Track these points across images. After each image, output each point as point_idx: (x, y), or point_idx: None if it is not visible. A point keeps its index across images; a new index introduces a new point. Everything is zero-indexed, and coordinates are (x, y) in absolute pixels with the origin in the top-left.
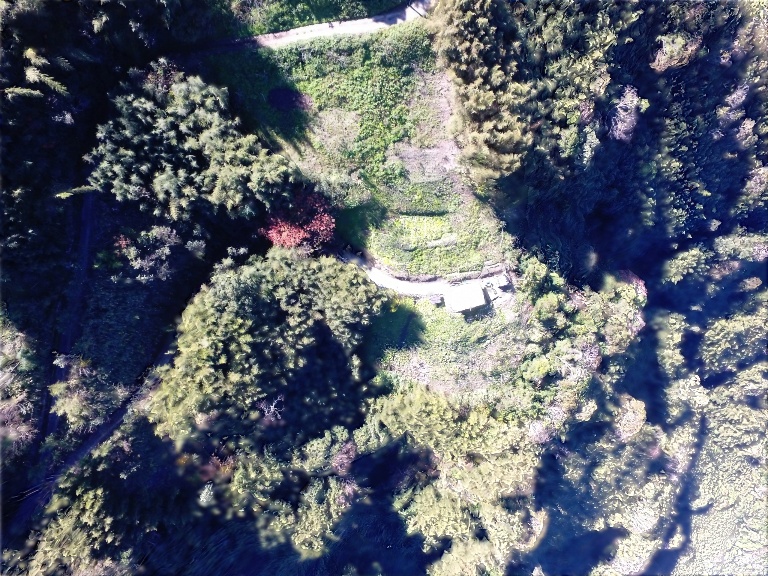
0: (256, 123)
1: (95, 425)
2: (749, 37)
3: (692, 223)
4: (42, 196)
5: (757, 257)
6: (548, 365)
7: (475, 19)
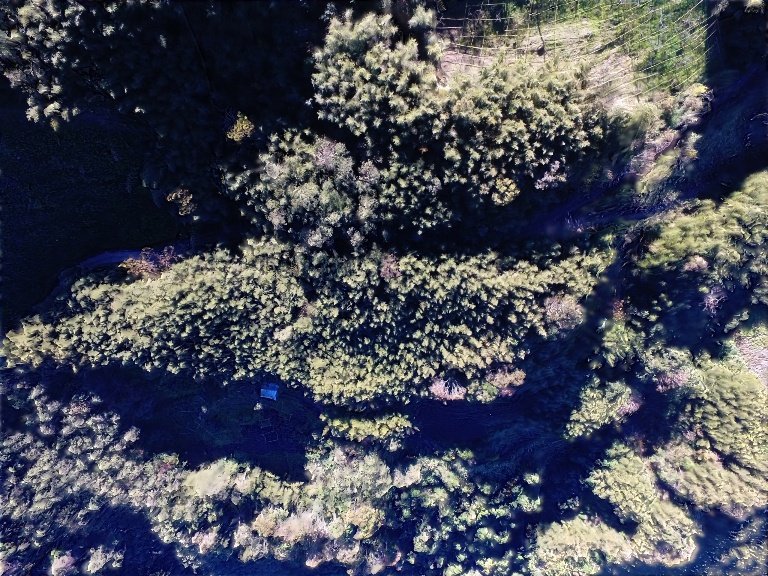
0: None
1: (639, 209)
2: None
3: None
4: None
5: None
6: None
7: None
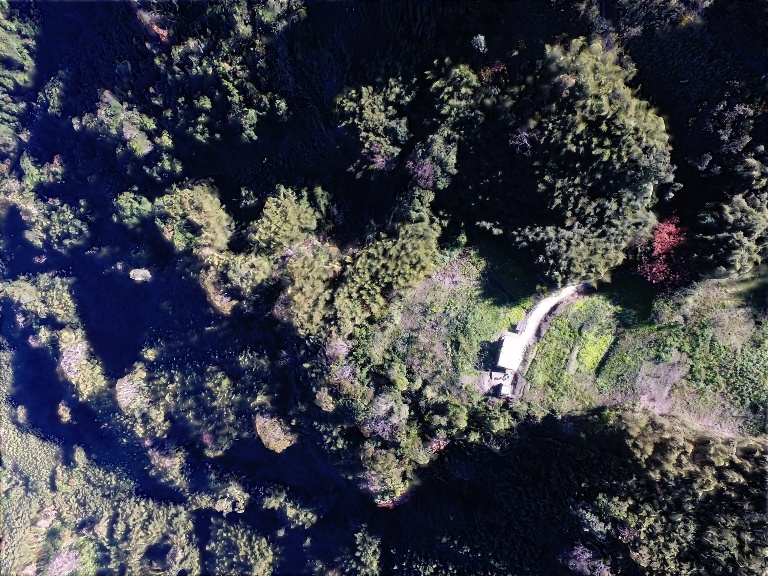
0: None
1: None
2: None
3: (408, 575)
4: None
5: None
6: (401, 389)
7: None
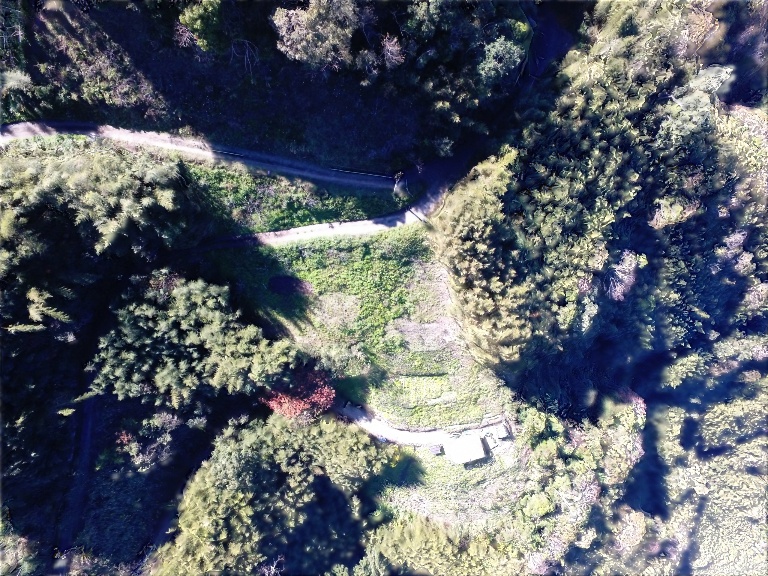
0: (257, 305)
1: None
2: (747, 191)
3: (691, 335)
4: (44, 411)
5: (756, 356)
6: (547, 506)
7: (474, 246)
